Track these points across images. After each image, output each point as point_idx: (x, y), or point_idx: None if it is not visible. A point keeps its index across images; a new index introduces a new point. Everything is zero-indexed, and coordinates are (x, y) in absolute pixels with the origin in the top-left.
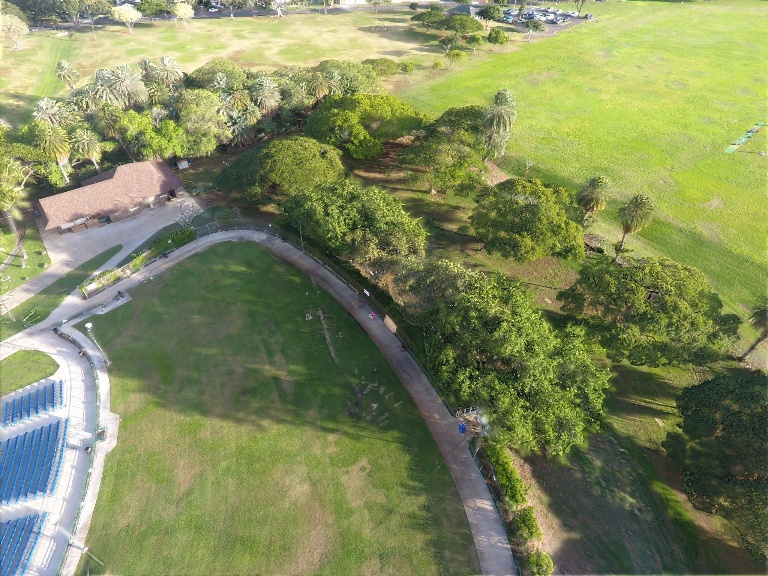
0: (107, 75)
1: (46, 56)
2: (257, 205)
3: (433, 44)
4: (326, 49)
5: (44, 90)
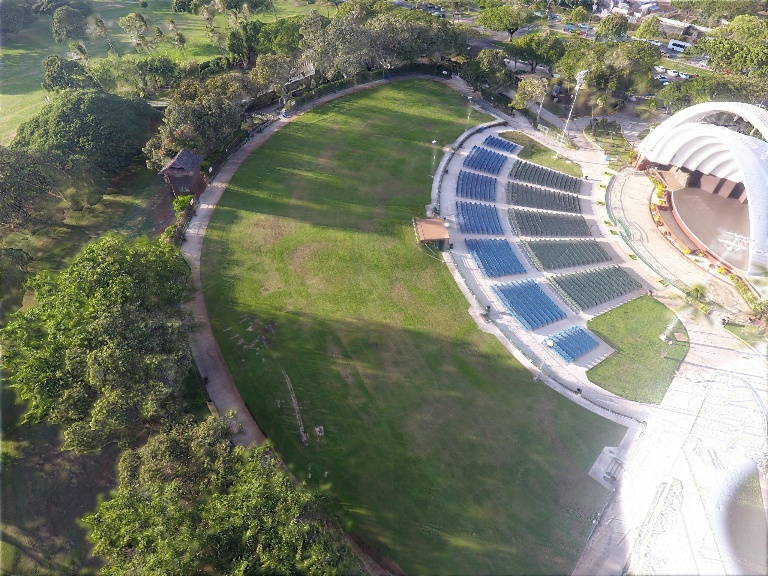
0: None
1: None
2: None
3: None
4: None
5: None
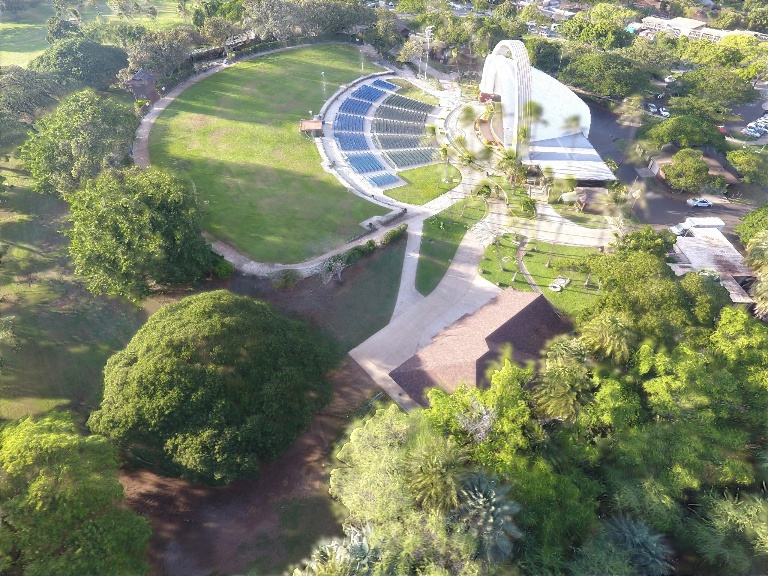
0: None
1: None
2: None
3: None
4: None
5: None
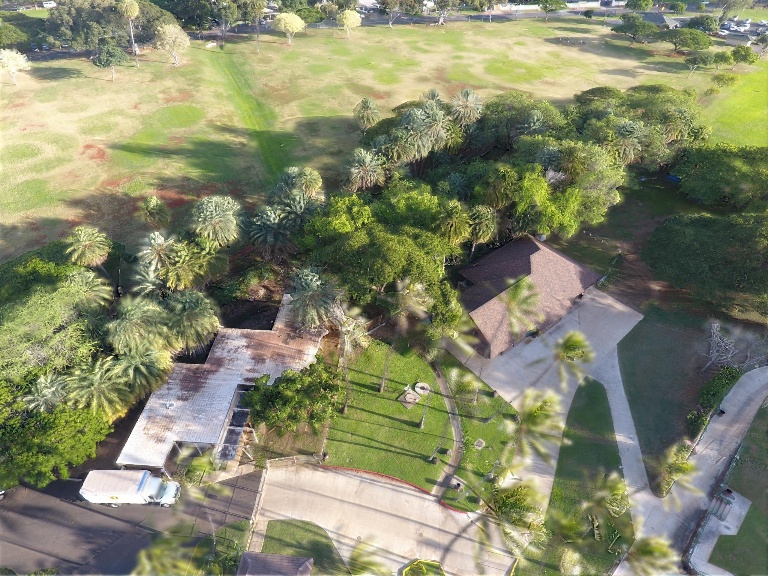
0: (421, 117)
1: (215, 74)
2: (719, 308)
3: (654, 61)
4: (537, 67)
5: (252, 120)
